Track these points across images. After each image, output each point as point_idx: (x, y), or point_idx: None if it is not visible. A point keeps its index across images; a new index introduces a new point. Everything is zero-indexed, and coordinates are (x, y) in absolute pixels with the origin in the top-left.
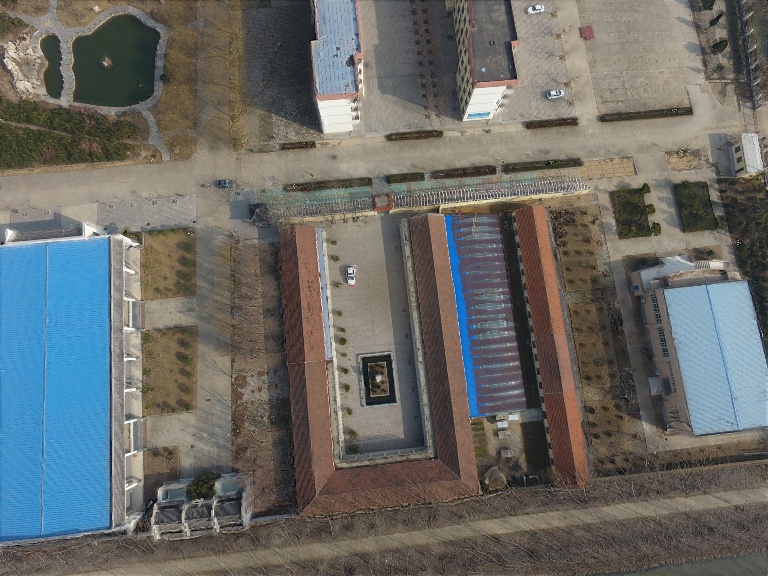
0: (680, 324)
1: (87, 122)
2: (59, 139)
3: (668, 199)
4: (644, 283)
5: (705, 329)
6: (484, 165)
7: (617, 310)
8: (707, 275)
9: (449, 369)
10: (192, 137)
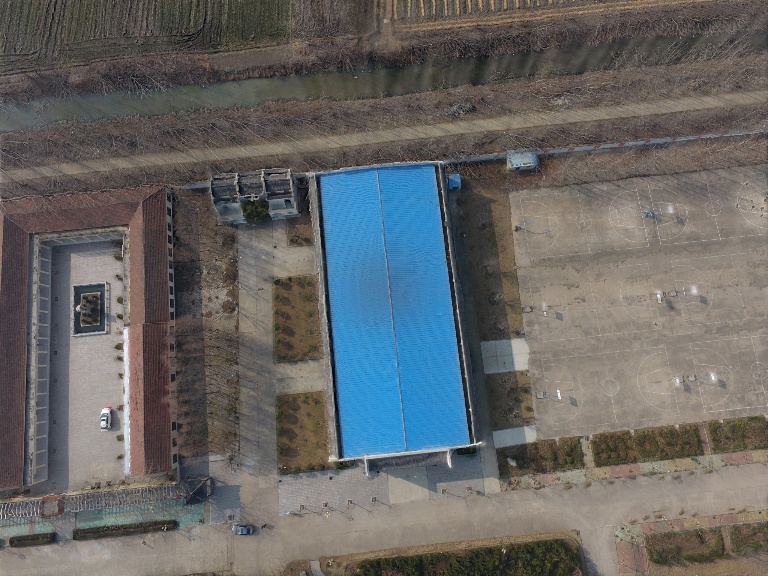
0: None
1: None
2: None
3: None
4: None
5: None
6: None
7: None
8: None
9: None
10: None
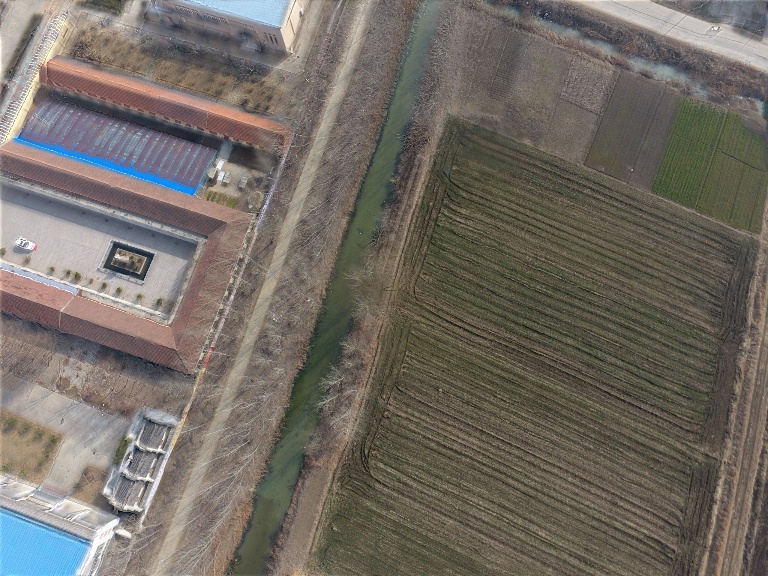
0: None
1: None
2: None
3: None
4: (164, 9)
5: None
6: None
7: (182, 44)
8: None
9: (138, 192)
10: None
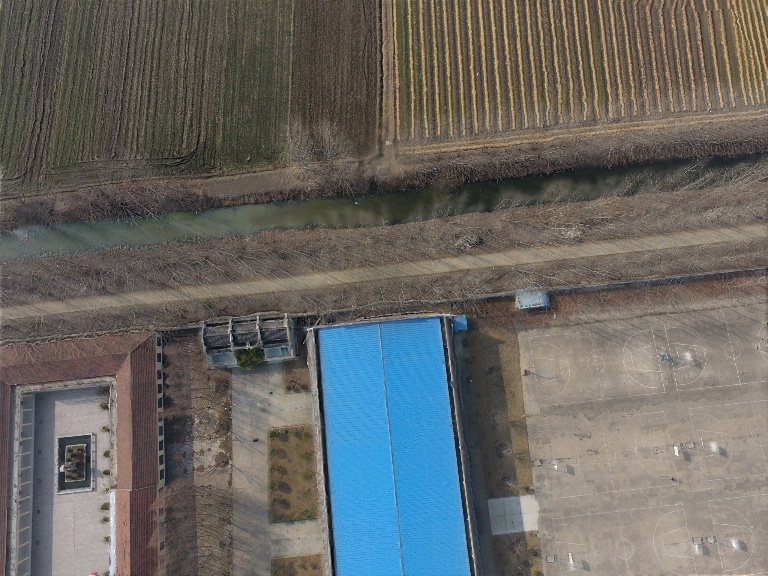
0: None
1: None
2: None
3: None
4: None
5: None
6: None
7: None
8: None
9: None
10: None
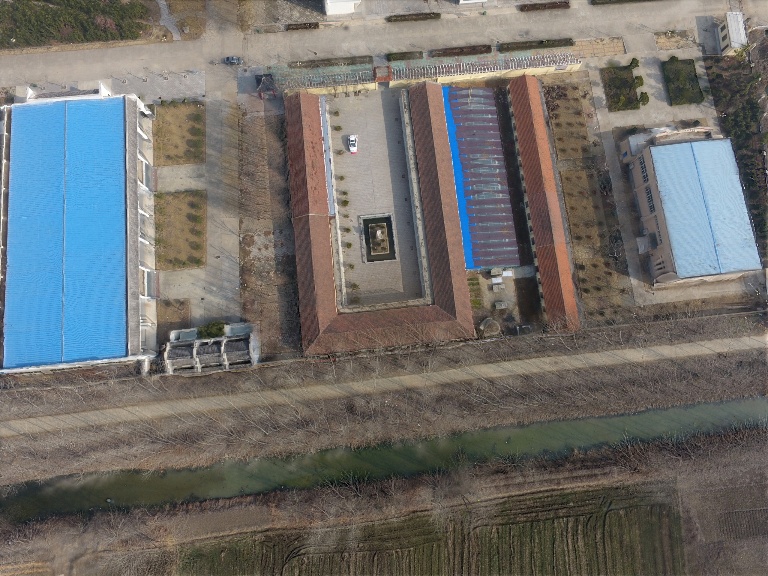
0: (666, 180)
1: (102, 0)
2: (75, 15)
3: (656, 75)
4: (632, 147)
5: (690, 184)
6: (480, 45)
7: (607, 176)
8: (692, 137)
9: (446, 221)
10: (201, 19)
